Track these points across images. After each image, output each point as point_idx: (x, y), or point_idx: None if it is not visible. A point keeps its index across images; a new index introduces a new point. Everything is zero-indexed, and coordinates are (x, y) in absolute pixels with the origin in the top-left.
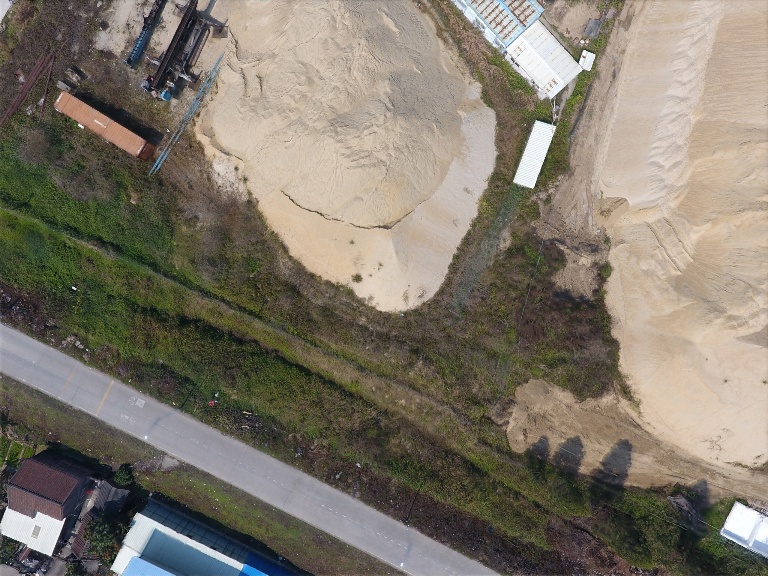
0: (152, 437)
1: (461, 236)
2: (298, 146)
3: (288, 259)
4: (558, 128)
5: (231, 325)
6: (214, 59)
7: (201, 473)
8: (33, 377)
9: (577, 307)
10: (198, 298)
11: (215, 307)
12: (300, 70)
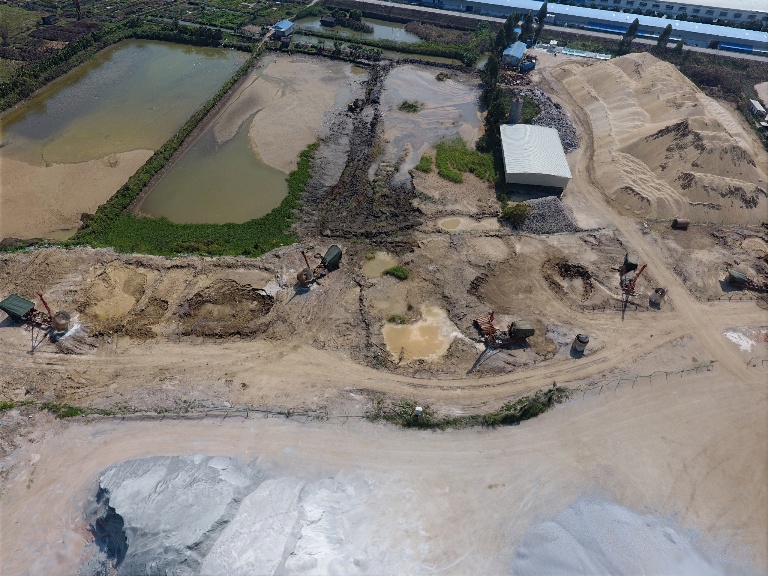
0: None
1: None
2: None
3: None
4: (752, 117)
5: None
6: None
7: None
8: None
9: (707, 80)
10: None
11: None
12: None
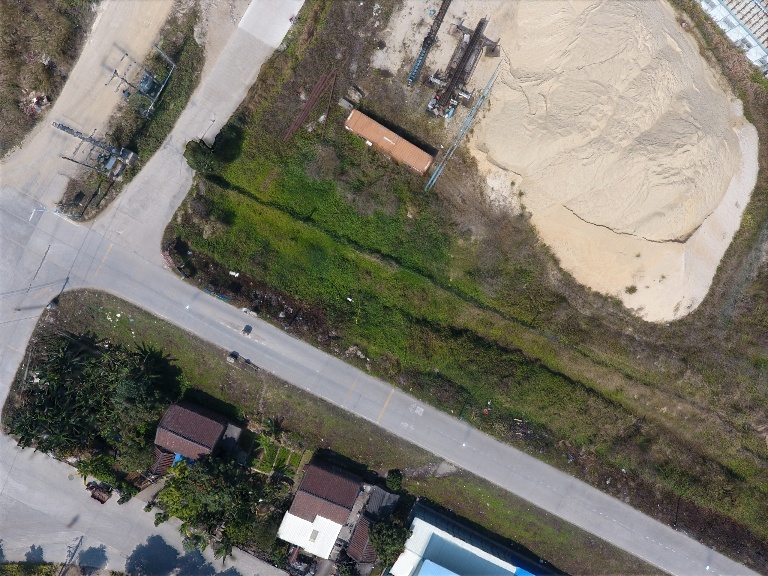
0: (431, 444)
1: (725, 248)
2: (599, 163)
3: (558, 271)
4: None
5: (499, 335)
6: (486, 77)
7: (478, 479)
8: (317, 386)
9: None
10: (474, 309)
11: (486, 317)
12: (598, 89)
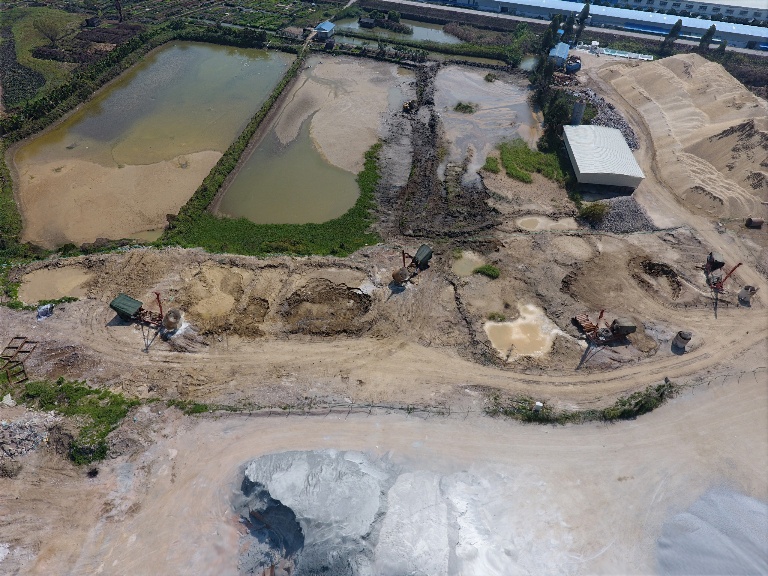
0: None
1: None
2: None
3: None
4: None
5: None
6: None
7: None
8: None
9: (754, 80)
10: None
11: None
12: None
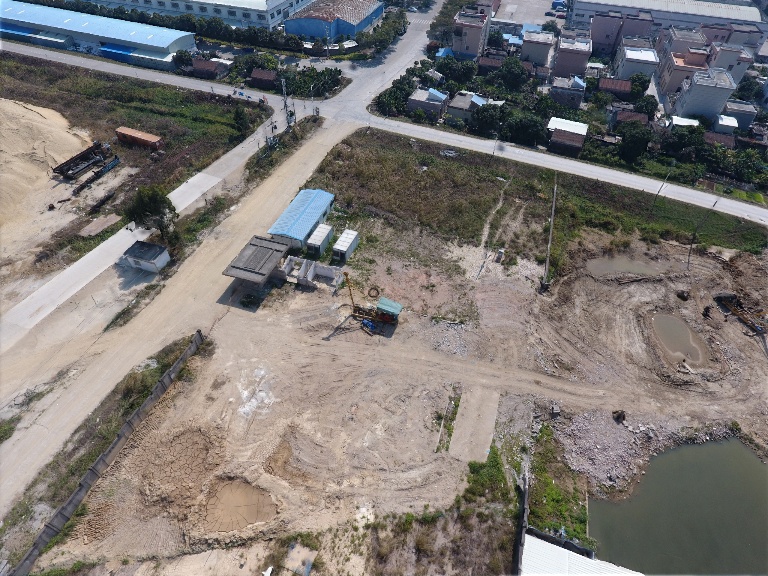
0: None
1: None
2: None
3: None
4: None
5: None
6: None
7: None
8: None
9: None
10: None
11: None
12: None
